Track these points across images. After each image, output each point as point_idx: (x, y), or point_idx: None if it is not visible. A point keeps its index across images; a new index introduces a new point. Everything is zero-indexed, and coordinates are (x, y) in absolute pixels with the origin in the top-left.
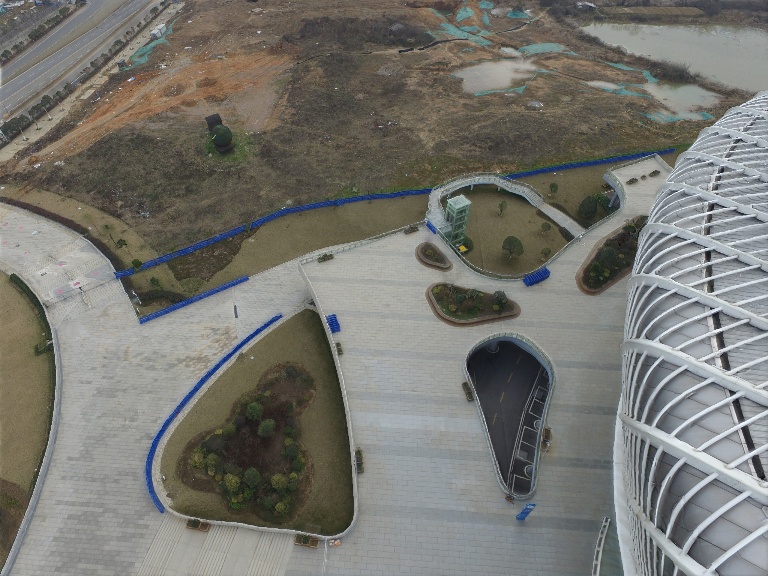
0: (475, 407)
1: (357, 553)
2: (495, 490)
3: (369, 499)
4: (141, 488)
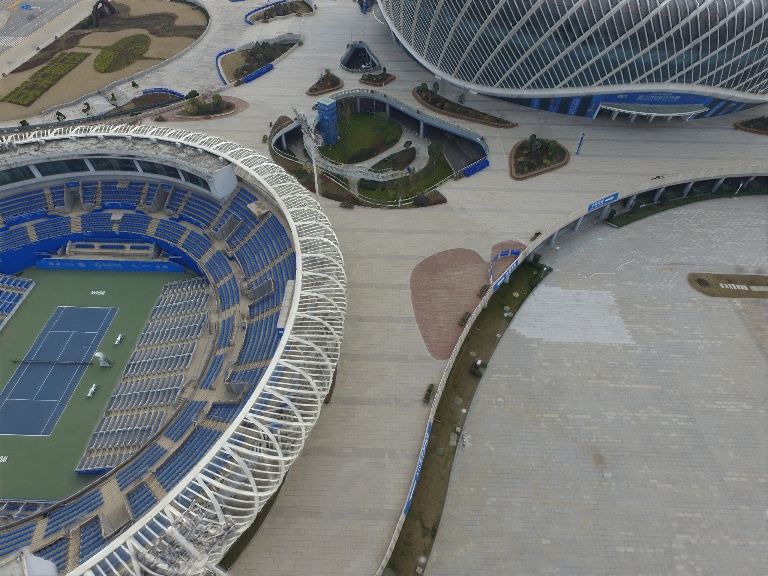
0: (356, 2)
1: (314, 17)
2: (358, 11)
3: (318, 12)
4: (244, 22)
